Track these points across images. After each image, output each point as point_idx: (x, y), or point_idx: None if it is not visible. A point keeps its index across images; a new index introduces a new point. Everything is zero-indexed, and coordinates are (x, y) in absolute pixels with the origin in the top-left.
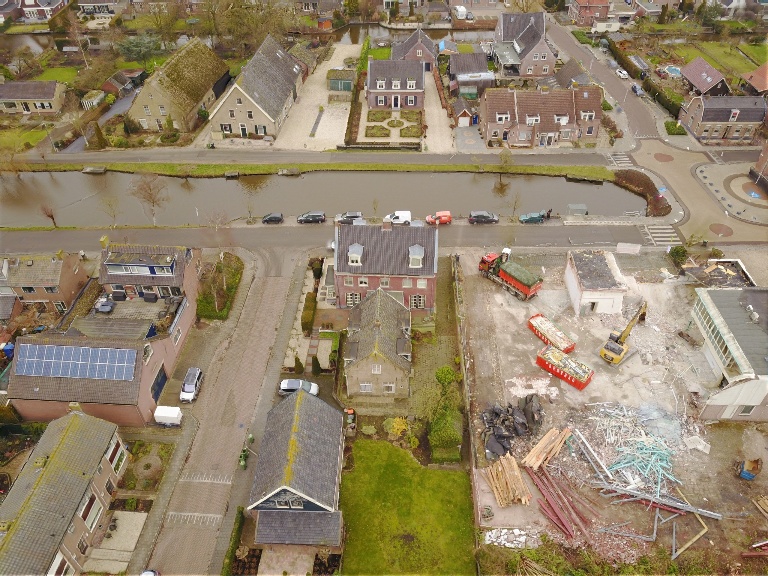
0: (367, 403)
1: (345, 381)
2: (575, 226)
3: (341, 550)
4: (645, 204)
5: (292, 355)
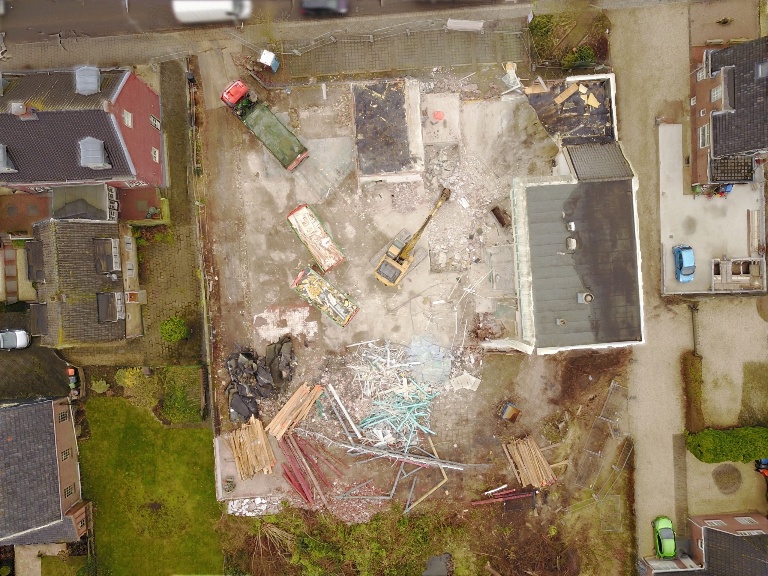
0: (93, 348)
1: None
2: None
3: (87, 532)
4: None
5: None
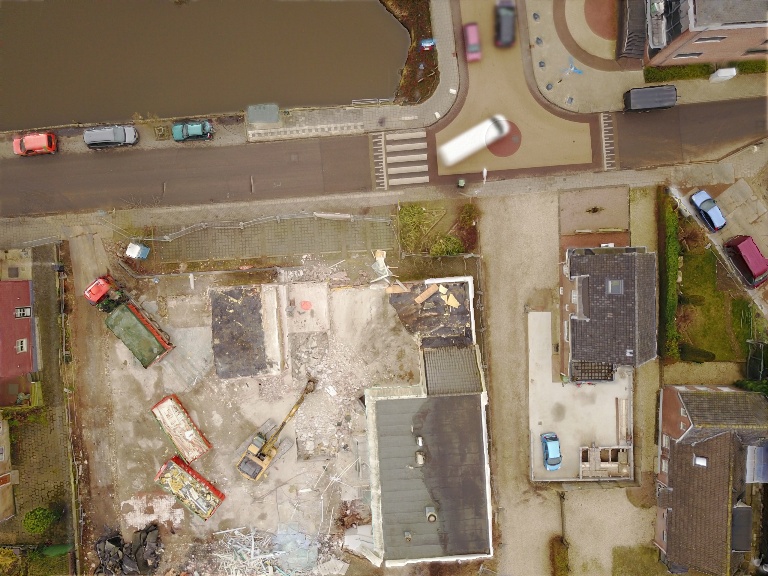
0: None
1: None
2: (266, 144)
3: None
4: None
5: None
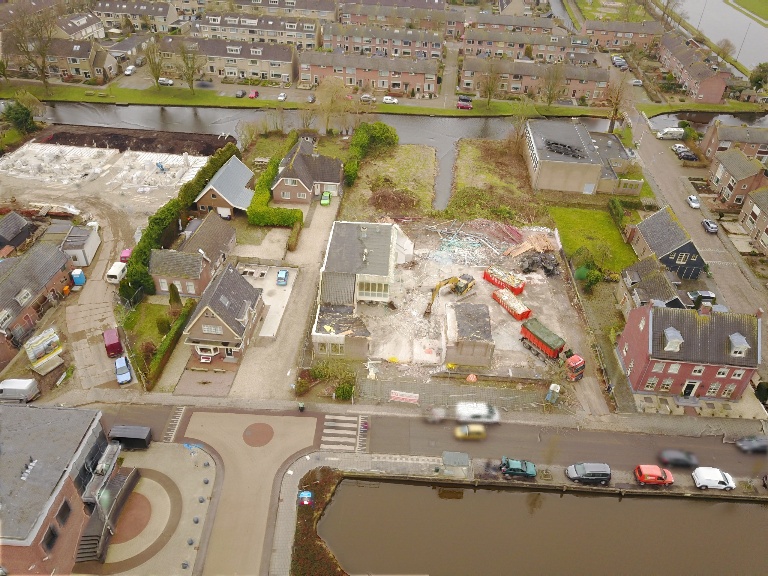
0: None
1: None
2: None
3: None
4: None
5: None
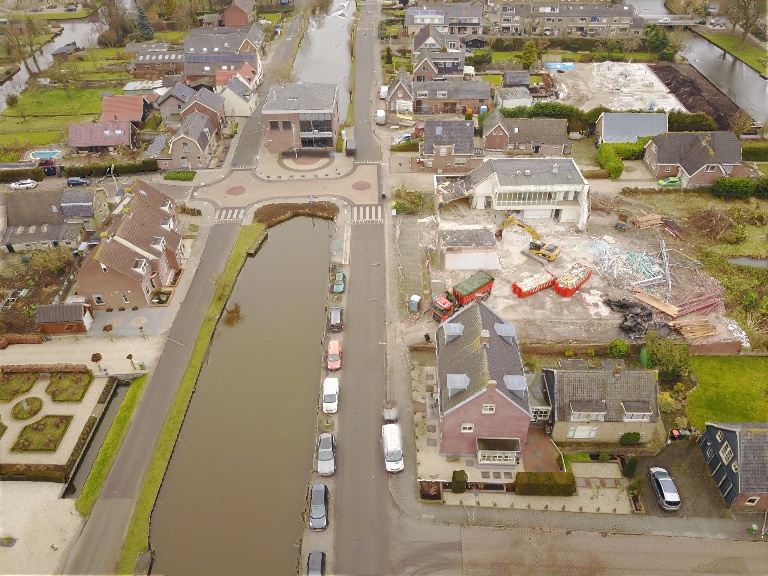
0: None
1: (639, 439)
2: (351, 258)
3: None
4: (301, 219)
5: (610, 505)
